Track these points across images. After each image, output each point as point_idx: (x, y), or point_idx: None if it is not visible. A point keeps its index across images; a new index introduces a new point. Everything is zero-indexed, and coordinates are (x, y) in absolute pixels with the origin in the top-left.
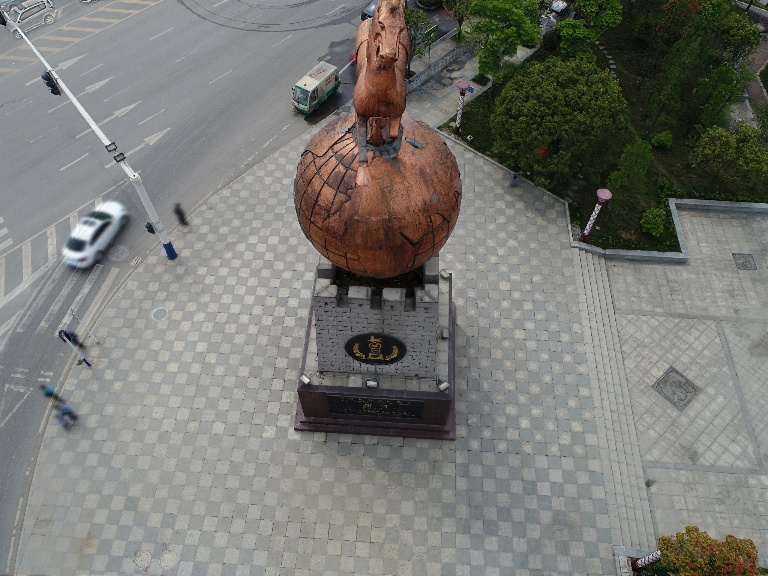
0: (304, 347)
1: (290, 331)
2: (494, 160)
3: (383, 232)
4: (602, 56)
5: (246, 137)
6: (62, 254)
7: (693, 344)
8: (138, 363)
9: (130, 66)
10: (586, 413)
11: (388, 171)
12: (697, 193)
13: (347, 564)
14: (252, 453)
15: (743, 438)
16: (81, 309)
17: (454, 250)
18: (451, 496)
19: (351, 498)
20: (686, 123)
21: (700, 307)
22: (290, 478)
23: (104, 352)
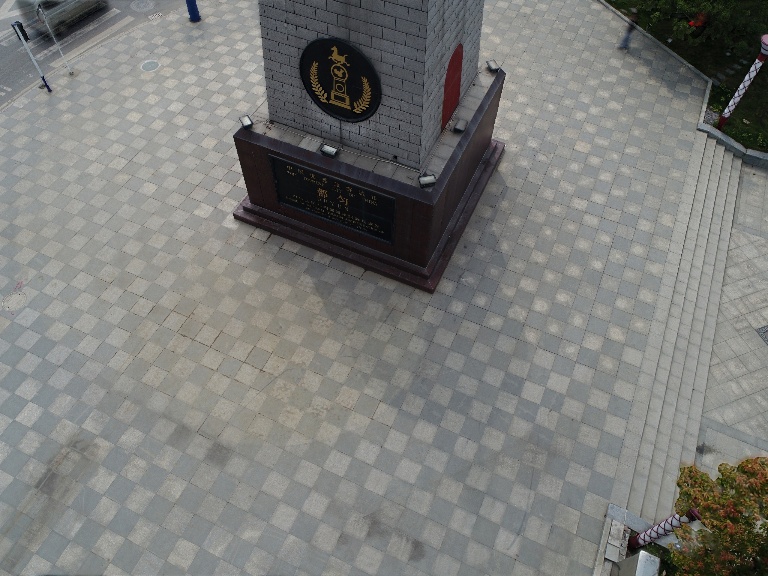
0: None
1: None
2: (628, 18)
3: None
4: None
5: None
6: None
7: None
8: (100, 103)
9: None
10: (638, 322)
11: None
12: None
13: (218, 383)
14: (172, 225)
15: None
16: (75, 42)
17: (531, 93)
18: (396, 355)
19: (263, 312)
20: None
21: None
22: (201, 266)
23: (72, 83)
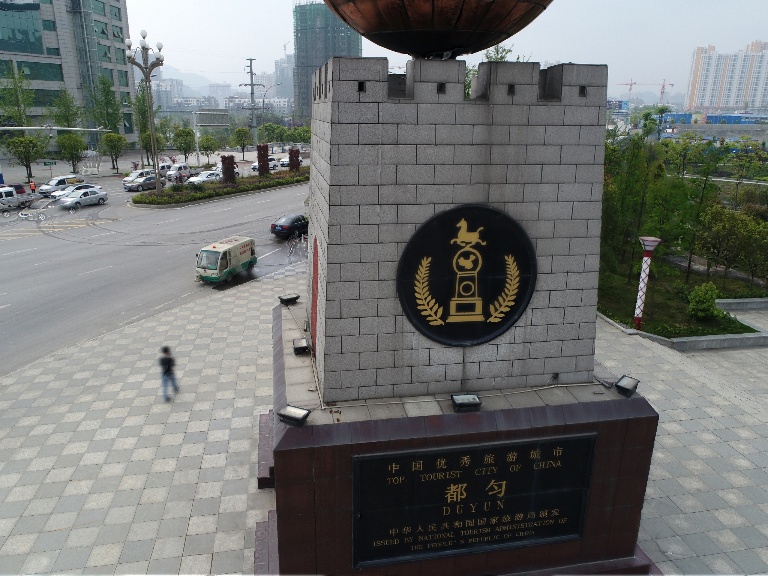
0: (274, 386)
1: (217, 473)
2: None
3: None
4: None
5: (129, 303)
6: None
7: None
8: None
9: None
10: None
11: None
12: (721, 293)
13: None
14: None
15: None
16: None
17: None
18: None
19: None
20: None
21: None
22: None
23: None
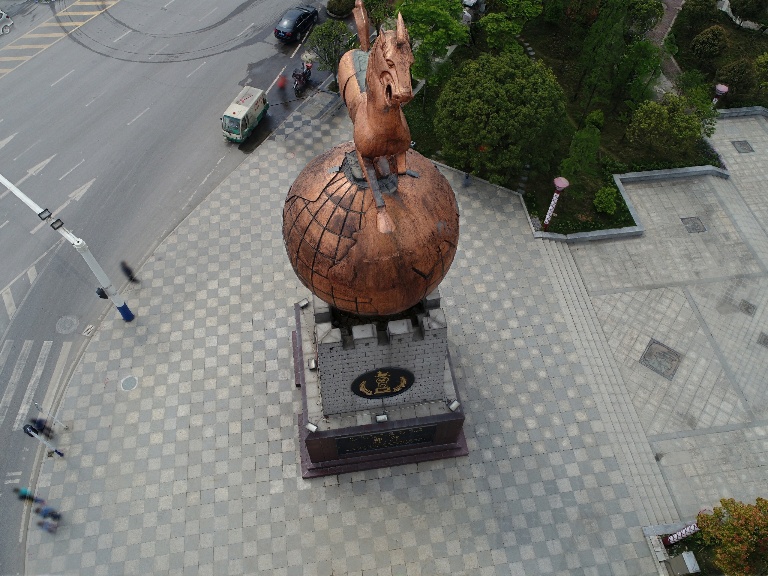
0: (301, 393)
1: (275, 375)
2: (441, 163)
3: (395, 271)
4: (520, 44)
5: (181, 176)
6: (2, 337)
7: (666, 313)
8: (117, 442)
9: (35, 118)
10: (586, 401)
11: (391, 207)
12: (638, 166)
13: None
14: (264, 513)
15: (731, 395)
16: (38, 394)
17: None
18: (477, 513)
19: (378, 538)
20: (611, 99)
21: (664, 276)
22: (310, 531)
23: (75, 437)
